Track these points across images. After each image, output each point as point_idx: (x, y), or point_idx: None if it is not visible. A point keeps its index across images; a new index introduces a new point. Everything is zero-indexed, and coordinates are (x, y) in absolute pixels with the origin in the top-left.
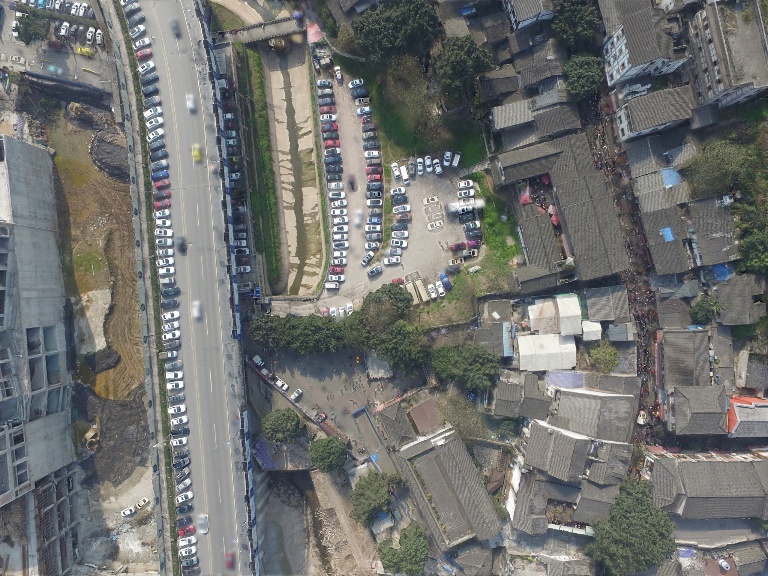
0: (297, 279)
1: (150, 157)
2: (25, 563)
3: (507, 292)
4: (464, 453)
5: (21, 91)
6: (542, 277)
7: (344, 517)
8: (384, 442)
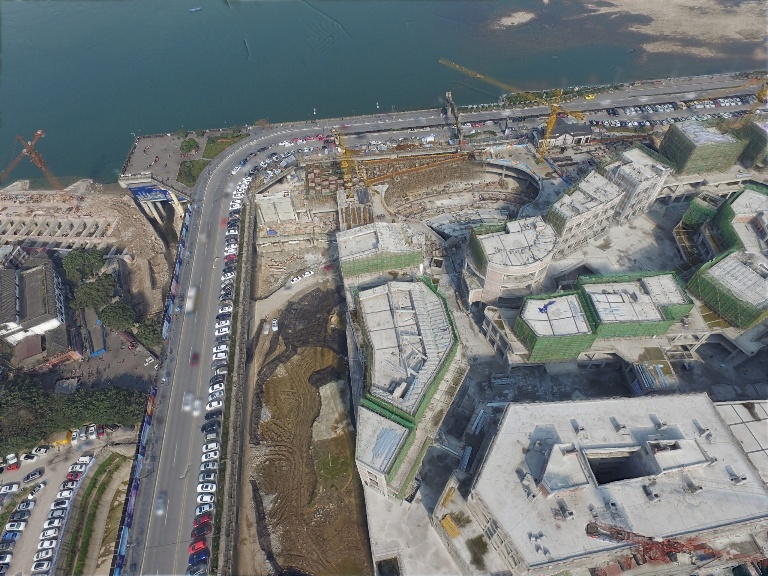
0: None
1: None
2: None
3: None
4: None
5: None
6: None
7: (146, 285)
8: None
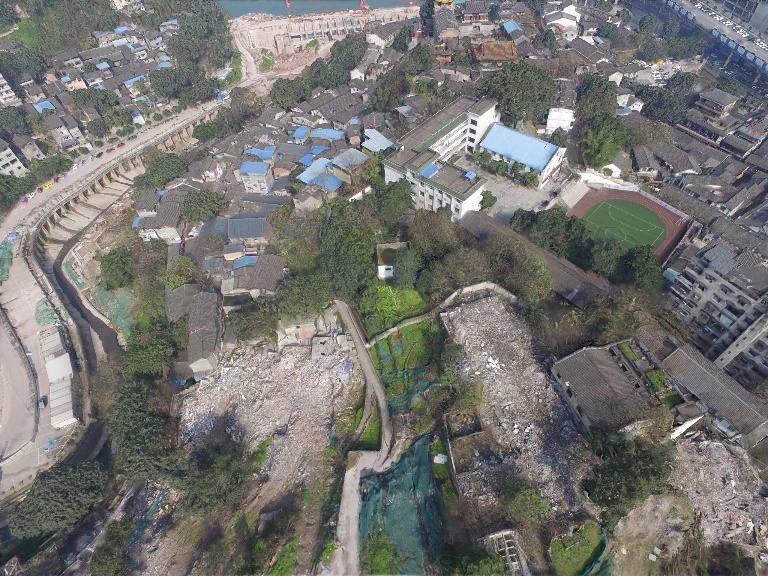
0: None
1: None
2: None
3: None
4: None
5: None
6: (600, 44)
7: None
8: None
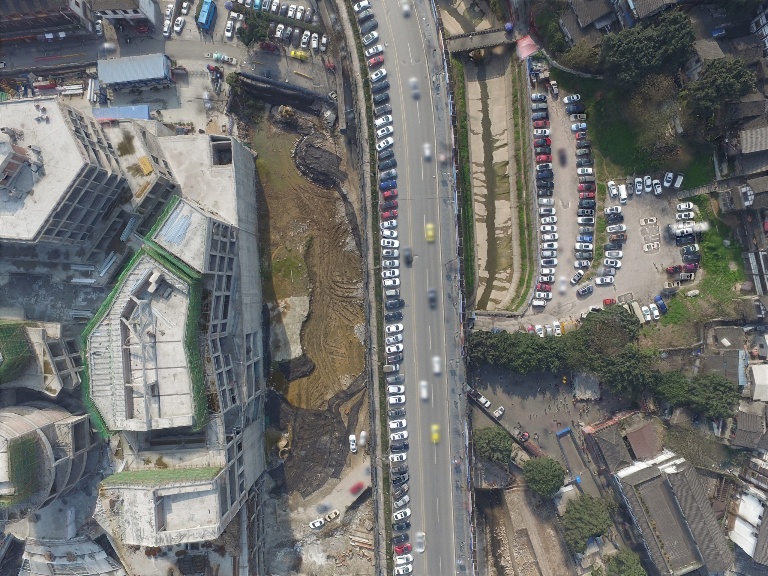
0: (486, 293)
1: (379, 166)
2: (235, 574)
3: (736, 319)
4: (698, 482)
5: (232, 92)
6: None
7: (537, 538)
8: (589, 465)
